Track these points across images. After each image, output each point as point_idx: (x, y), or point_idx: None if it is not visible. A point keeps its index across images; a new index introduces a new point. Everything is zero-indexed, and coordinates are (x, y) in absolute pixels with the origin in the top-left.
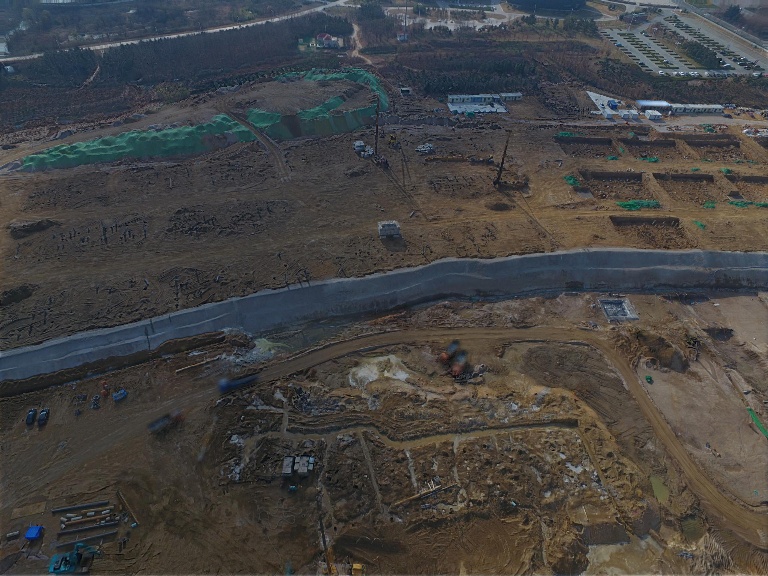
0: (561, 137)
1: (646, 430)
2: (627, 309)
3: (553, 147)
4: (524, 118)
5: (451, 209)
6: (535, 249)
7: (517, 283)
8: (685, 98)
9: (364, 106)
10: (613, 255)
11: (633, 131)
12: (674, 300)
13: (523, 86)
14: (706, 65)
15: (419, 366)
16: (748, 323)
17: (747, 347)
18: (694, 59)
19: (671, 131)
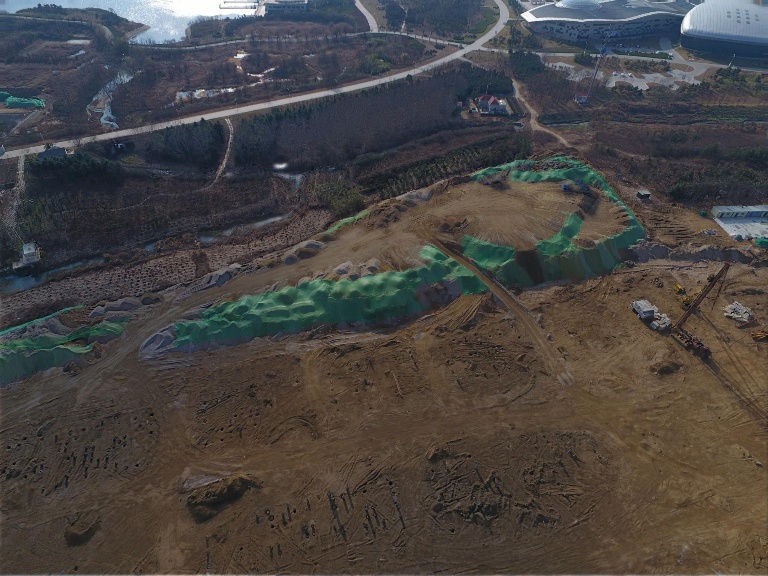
0: None
1: None
2: None
3: None
4: None
5: None
6: None
7: None
8: None
9: (616, 230)
10: None
11: None
12: None
13: None
14: None
15: None
16: None
17: None
18: None
19: None
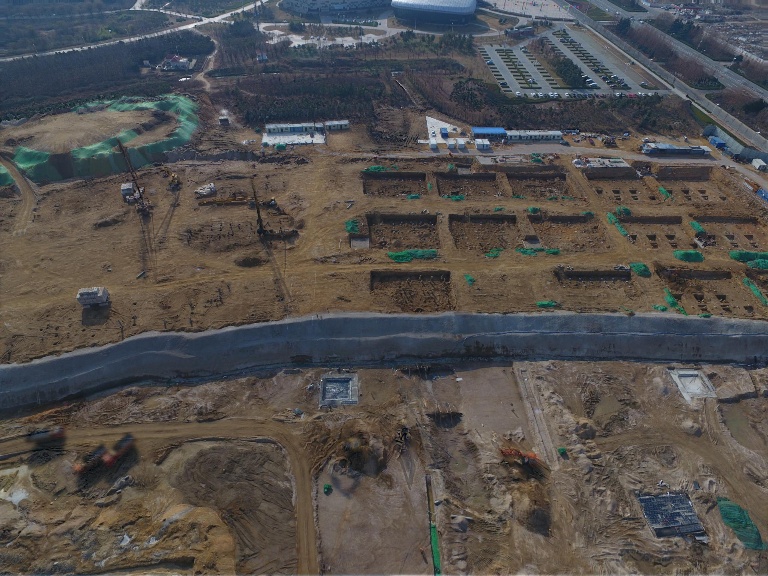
0: (370, 172)
1: (287, 565)
2: (350, 389)
3: (354, 185)
4: (339, 150)
5: (192, 266)
6: (261, 317)
7: (228, 360)
8: (531, 123)
9: (157, 140)
10: (349, 322)
11: (455, 163)
12: (413, 374)
13: (359, 112)
14: (571, 84)
15: (49, 481)
16: (484, 404)
17: (469, 437)
18: (562, 78)
19: (494, 163)
